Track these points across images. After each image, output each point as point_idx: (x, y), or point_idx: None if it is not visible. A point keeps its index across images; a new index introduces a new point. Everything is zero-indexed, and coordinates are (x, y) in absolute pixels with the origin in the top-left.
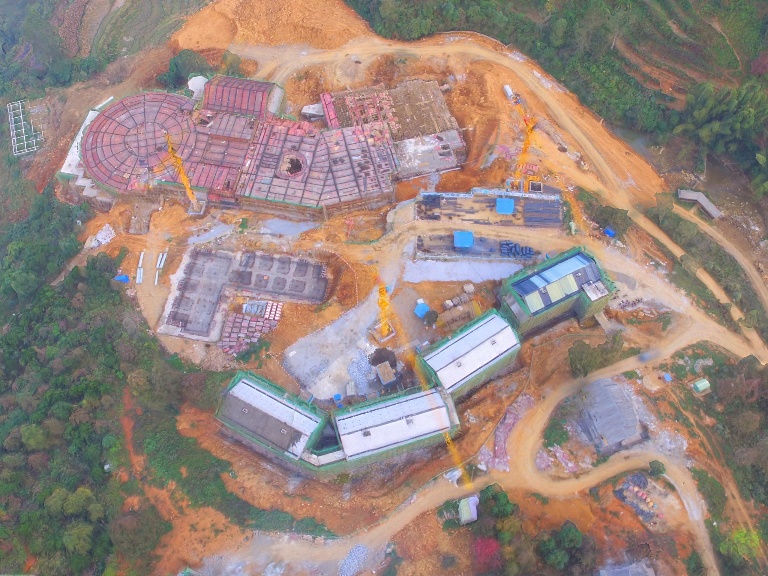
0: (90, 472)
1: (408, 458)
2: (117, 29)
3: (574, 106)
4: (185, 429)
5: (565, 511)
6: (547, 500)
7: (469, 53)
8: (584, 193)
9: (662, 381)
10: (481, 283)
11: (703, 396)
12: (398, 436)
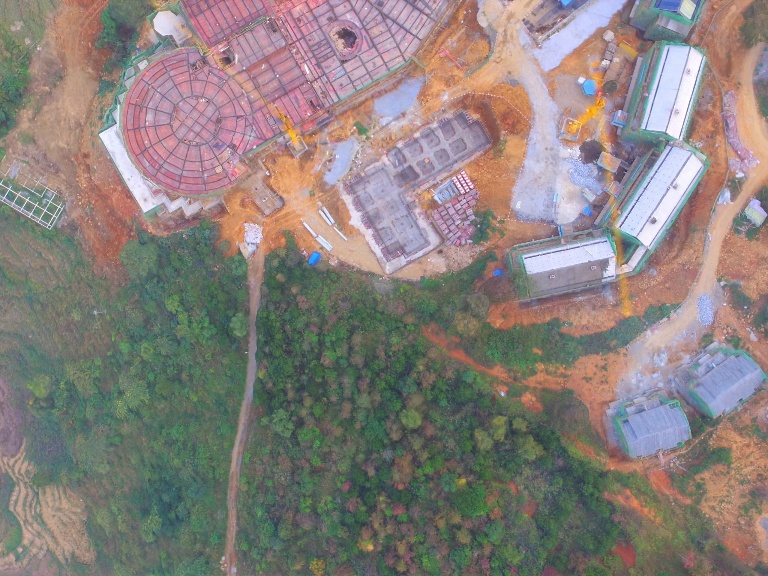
0: (482, 405)
1: None
2: None
3: None
4: (503, 324)
5: None
6: None
7: None
8: None
9: None
10: (610, 23)
11: None
12: (673, 203)
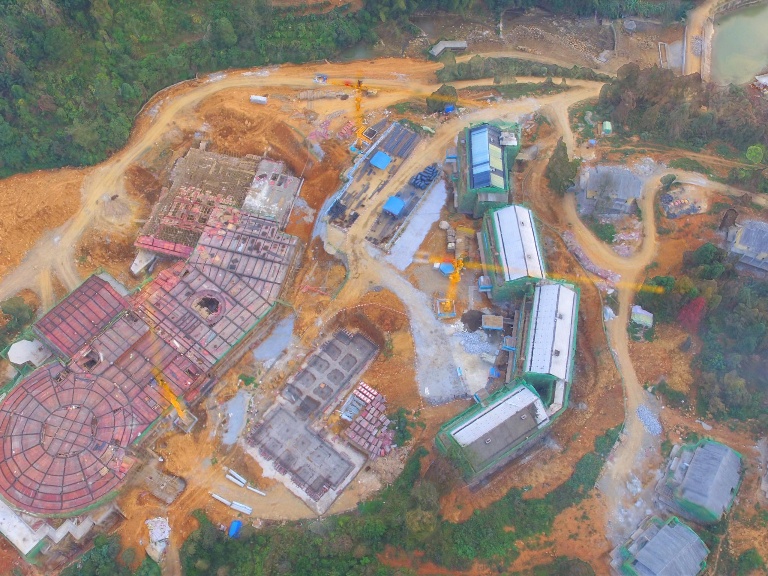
0: None
1: None
2: None
3: (300, 69)
4: (461, 515)
5: (668, 256)
6: (655, 263)
7: (184, 107)
8: (399, 106)
9: (591, 148)
10: (441, 216)
11: (613, 132)
12: (566, 333)
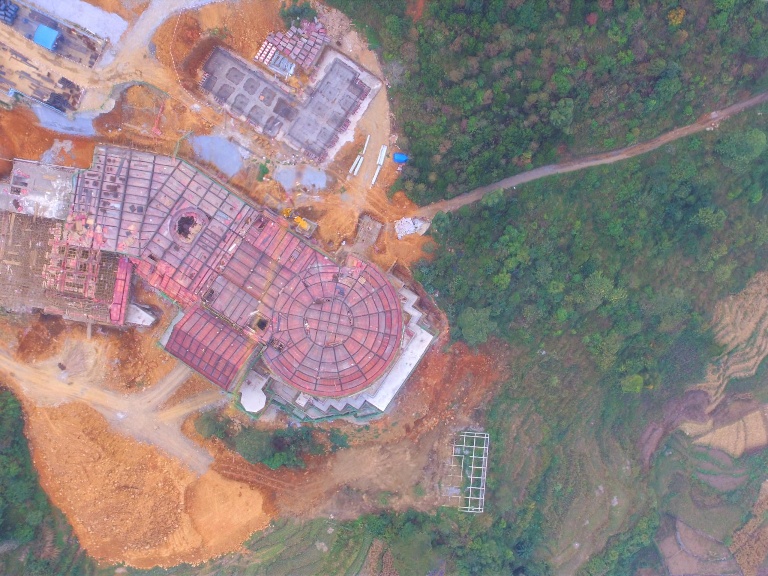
0: None
1: None
2: (331, 569)
3: None
4: None
5: None
6: None
7: None
8: None
9: None
10: None
11: None
12: None
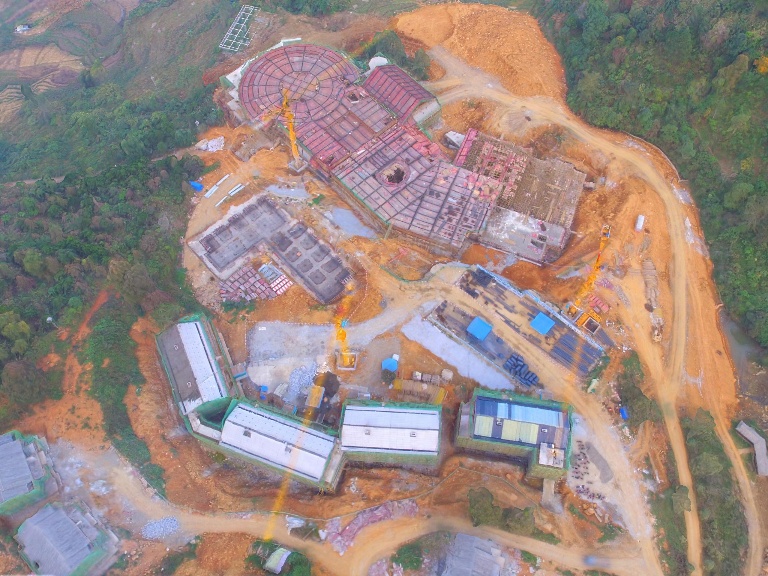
0: None
1: (280, 480)
2: None
3: (701, 274)
4: (136, 331)
5: None
6: None
7: (636, 166)
8: (634, 361)
9: None
10: (464, 377)
11: None
12: (272, 454)
